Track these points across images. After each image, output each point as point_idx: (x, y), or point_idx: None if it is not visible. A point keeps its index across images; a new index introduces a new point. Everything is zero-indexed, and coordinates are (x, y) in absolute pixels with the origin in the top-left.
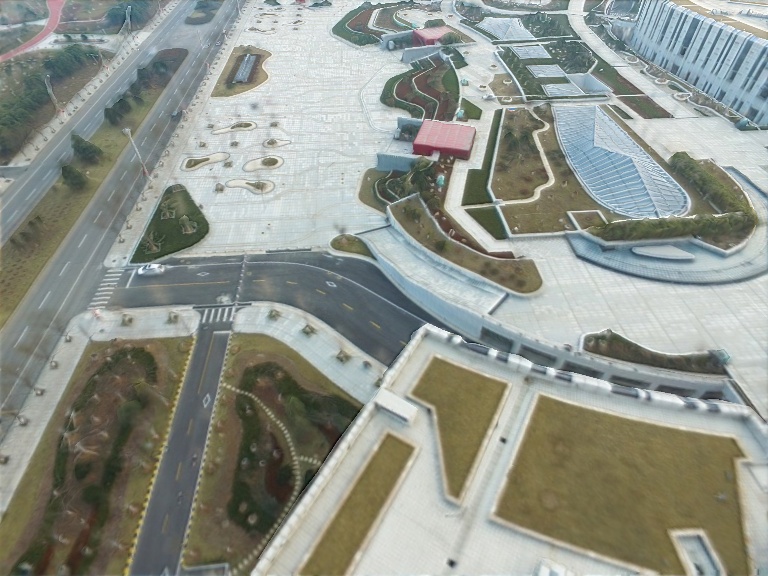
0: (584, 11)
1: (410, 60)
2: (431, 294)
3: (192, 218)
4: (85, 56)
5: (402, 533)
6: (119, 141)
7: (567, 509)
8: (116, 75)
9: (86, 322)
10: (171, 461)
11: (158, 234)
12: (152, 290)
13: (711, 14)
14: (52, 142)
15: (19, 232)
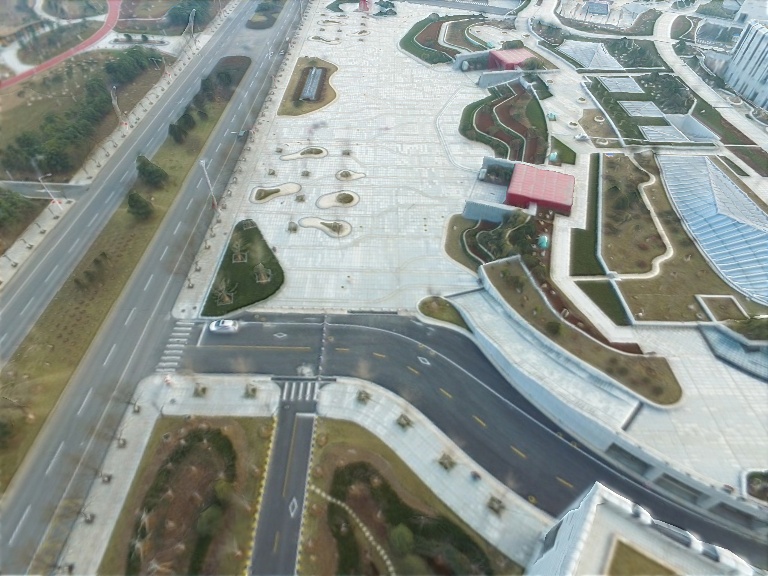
0: (672, 38)
1: (487, 85)
2: (548, 392)
3: (265, 263)
4: (147, 60)
5: None
6: (184, 162)
7: None
8: (178, 83)
9: (155, 388)
10: None
11: (230, 282)
12: (225, 352)
13: None
14: (114, 158)
15: (82, 268)
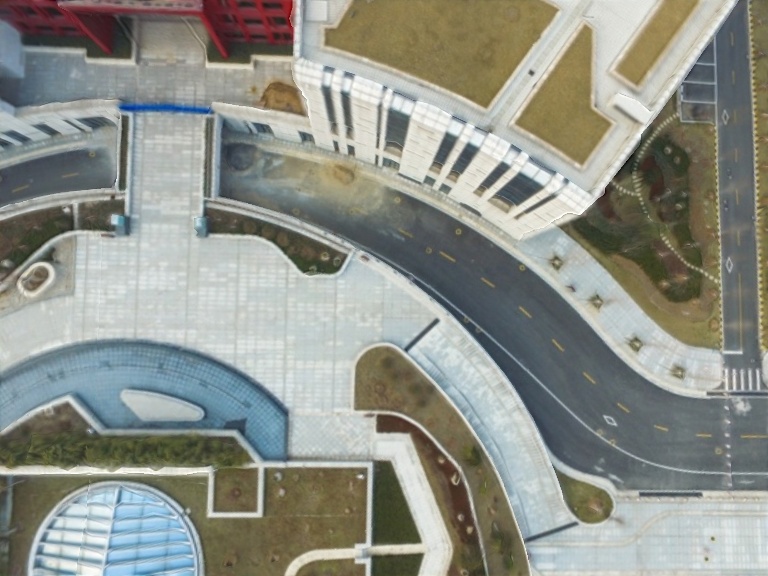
0: None
1: None
2: None
3: None
4: None
5: (630, 8)
6: None
7: (500, 5)
8: None
9: None
10: (746, 206)
11: None
12: None
13: None
14: None
15: None
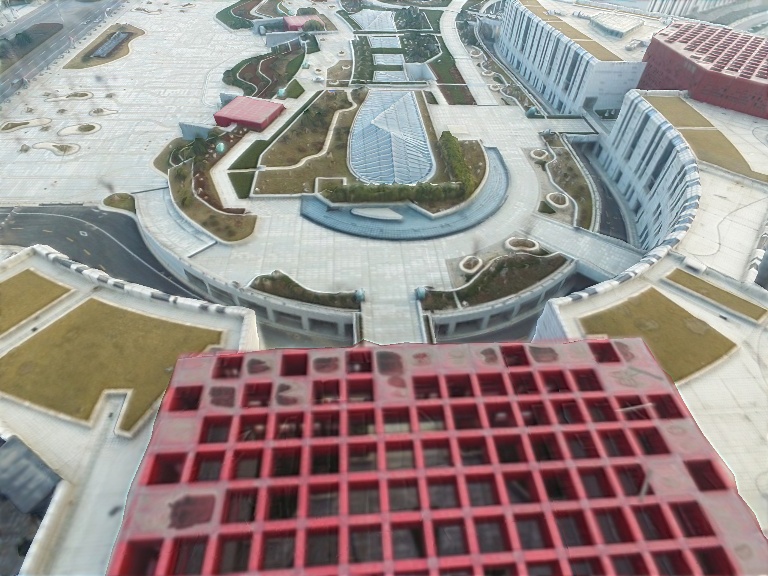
0: (462, 8)
1: (272, 44)
2: (153, 241)
3: None
4: None
5: None
6: None
7: (36, 374)
8: None
9: None
10: None
11: None
12: None
13: (545, 14)
14: None
15: None
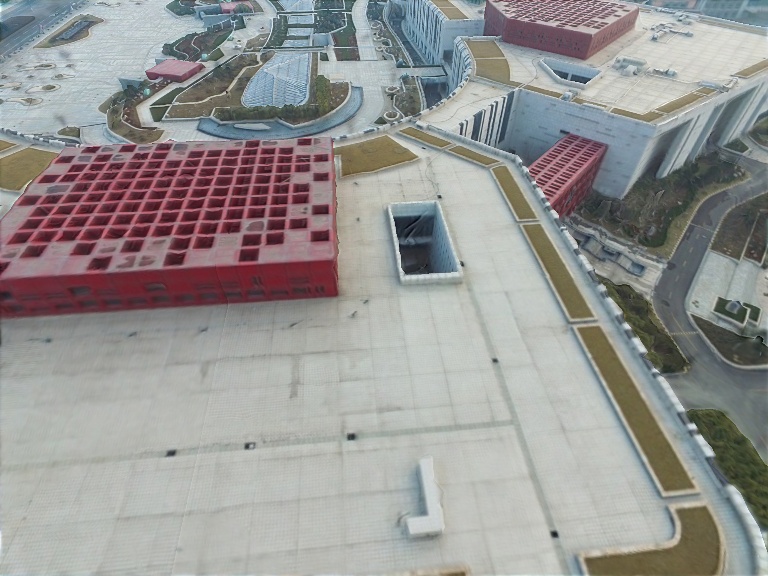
0: None
1: (209, 25)
2: None
3: None
4: None
5: None
6: None
7: None
8: None
9: None
10: None
11: None
12: None
13: None
14: None
15: None
